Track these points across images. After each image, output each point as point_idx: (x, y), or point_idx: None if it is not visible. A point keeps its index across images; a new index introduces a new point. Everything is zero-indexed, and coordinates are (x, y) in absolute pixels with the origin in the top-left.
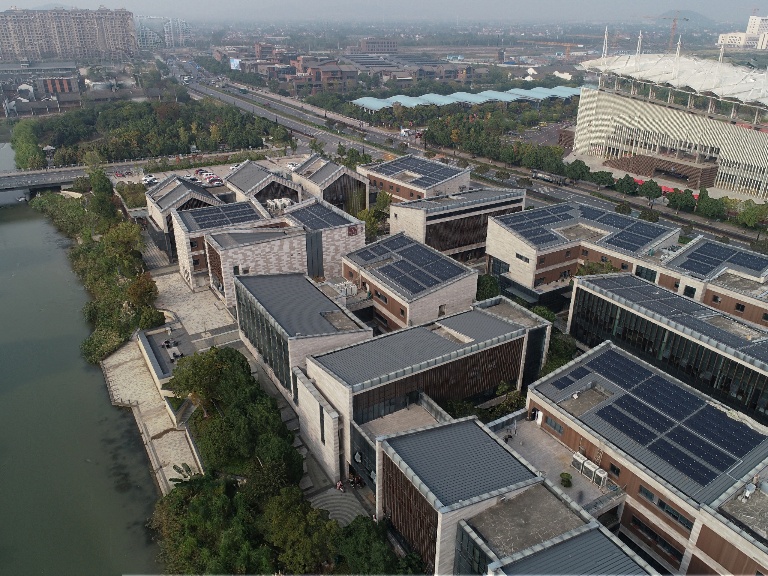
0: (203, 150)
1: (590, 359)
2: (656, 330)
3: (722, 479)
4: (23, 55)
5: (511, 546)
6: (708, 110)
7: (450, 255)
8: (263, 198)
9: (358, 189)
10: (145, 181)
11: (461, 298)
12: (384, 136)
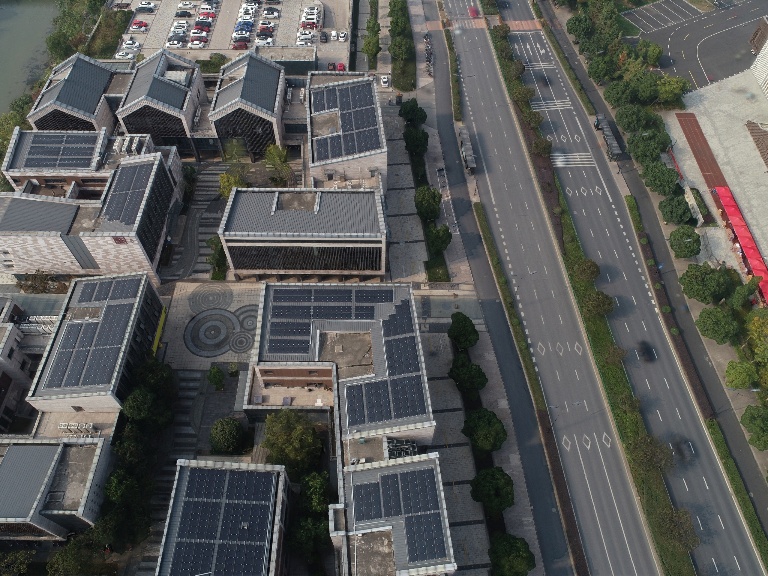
0: None
1: None
2: None
3: None
4: None
5: None
6: None
7: None
8: (139, 119)
9: (263, 126)
10: (140, 3)
11: (100, 405)
12: None
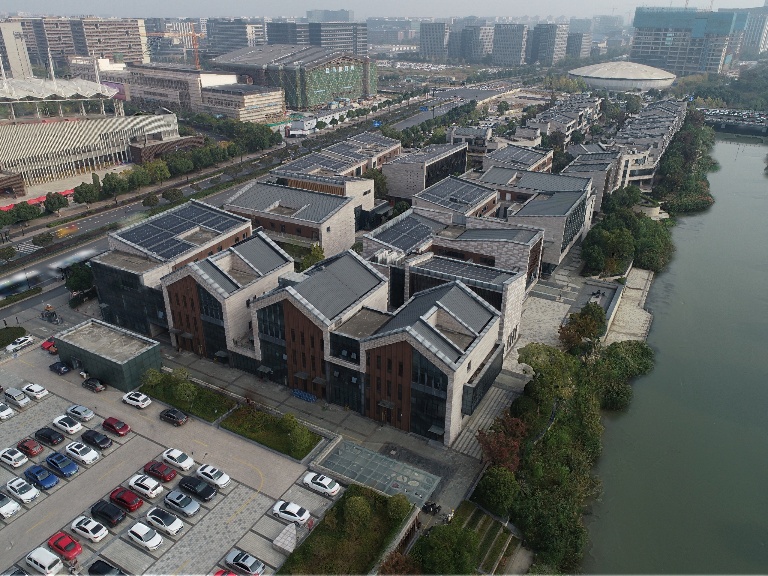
0: None
1: None
2: None
3: None
4: None
5: None
6: None
7: None
8: None
9: None
10: None
11: None
12: None
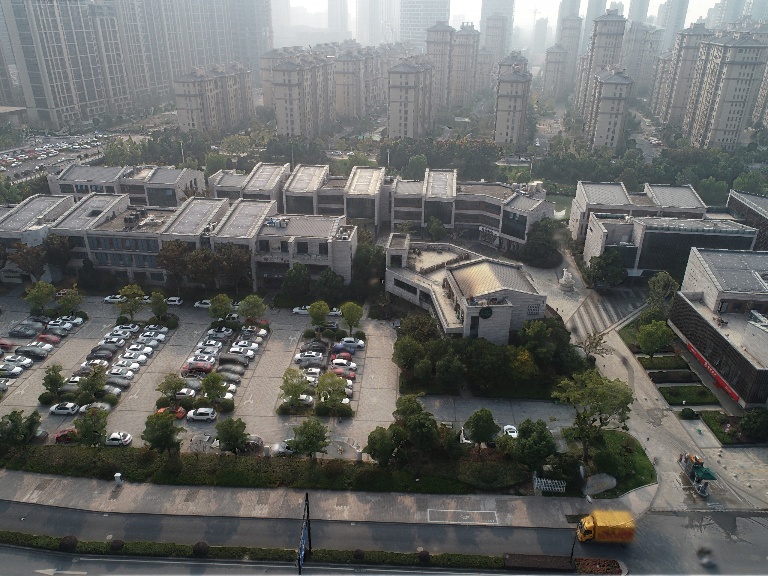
0: None
1: None
2: None
3: None
4: None
5: None
6: None
7: None
8: None
9: None
10: None
11: None
12: None
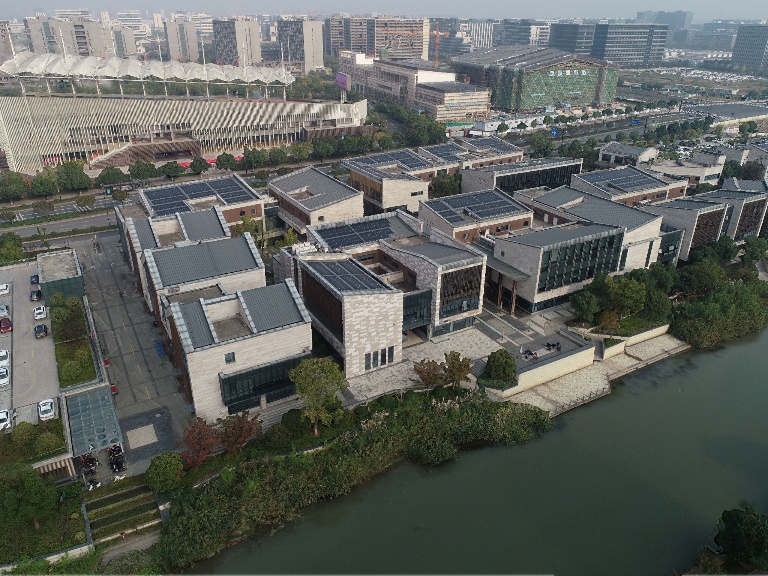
0: None
1: None
2: None
3: (652, 179)
4: None
5: None
6: (166, 94)
7: None
8: None
9: None
10: None
11: None
12: None
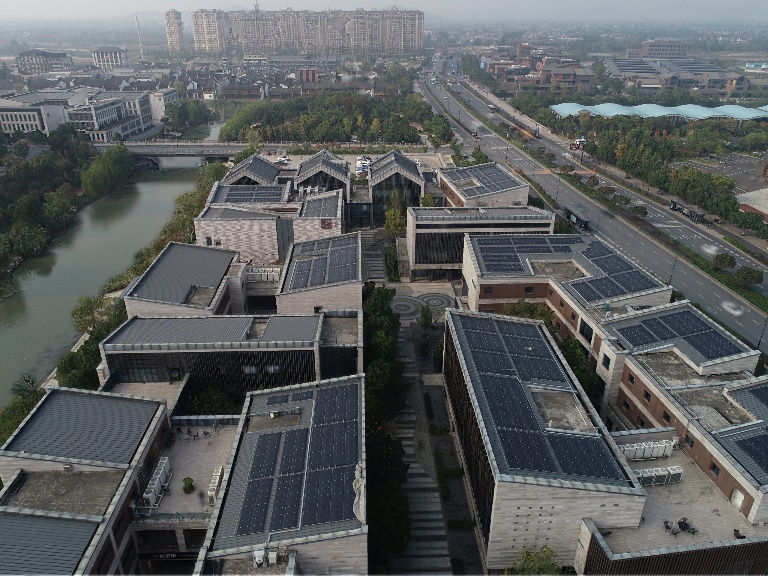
0: (360, 140)
1: (328, 386)
2: (462, 384)
3: (260, 536)
4: (235, 48)
5: (25, 504)
6: None
7: (448, 269)
8: (311, 185)
9: (412, 190)
10: None
11: (342, 305)
12: (555, 145)
